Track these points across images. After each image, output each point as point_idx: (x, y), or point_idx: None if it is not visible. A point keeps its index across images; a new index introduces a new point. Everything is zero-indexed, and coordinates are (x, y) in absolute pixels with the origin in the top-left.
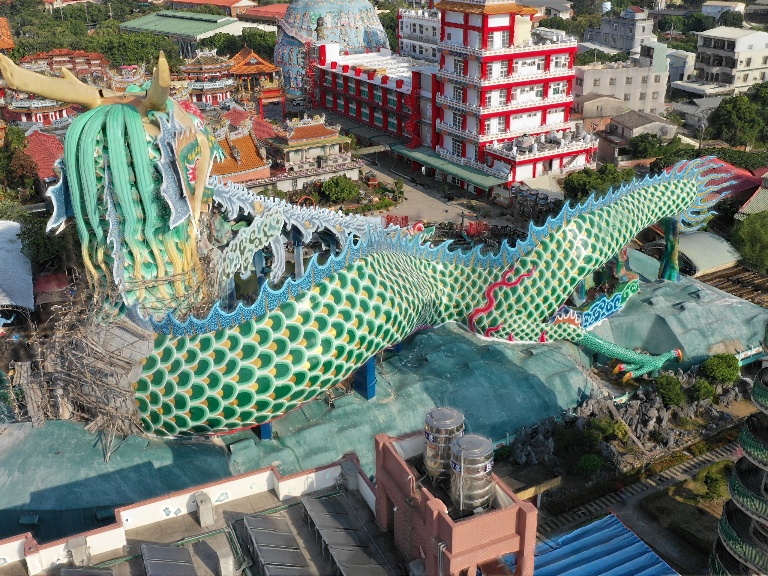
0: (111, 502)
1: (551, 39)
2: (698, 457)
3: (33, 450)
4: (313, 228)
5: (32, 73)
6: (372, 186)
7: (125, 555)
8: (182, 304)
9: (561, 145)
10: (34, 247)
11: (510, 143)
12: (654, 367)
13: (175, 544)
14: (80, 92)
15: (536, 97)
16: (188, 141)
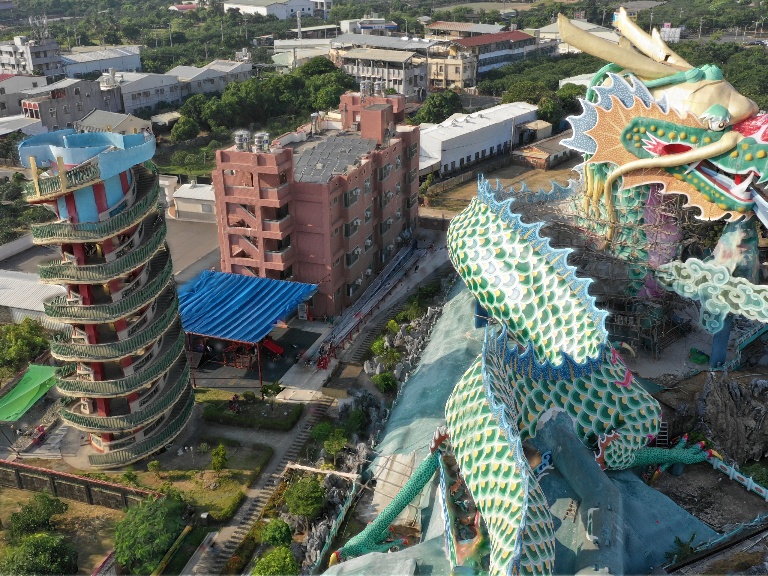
0: None
1: None
2: (254, 522)
3: None
4: None
5: None
6: None
7: None
8: None
9: None
10: None
11: None
12: None
13: None
14: None
15: None
16: None
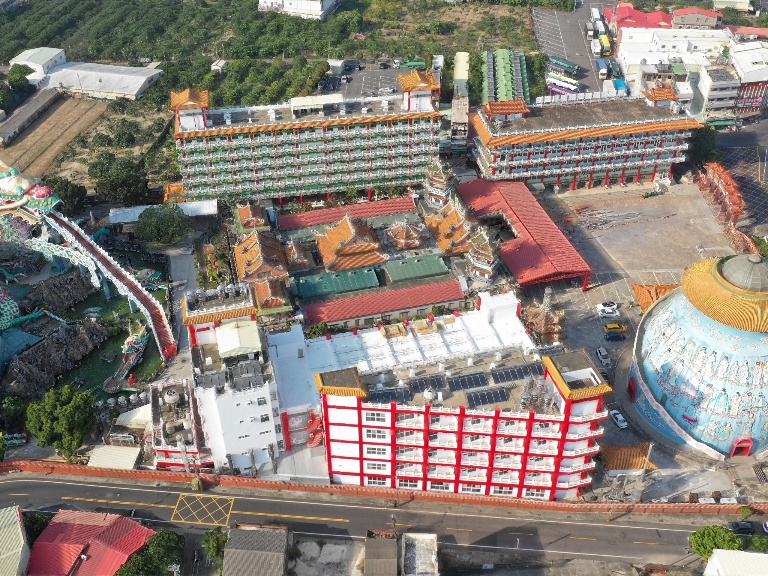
0: None
1: None
2: None
3: None
4: None
5: None
6: None
7: None
8: None
9: None
10: None
11: None
12: None
13: None
14: None
15: None
16: (3, 192)
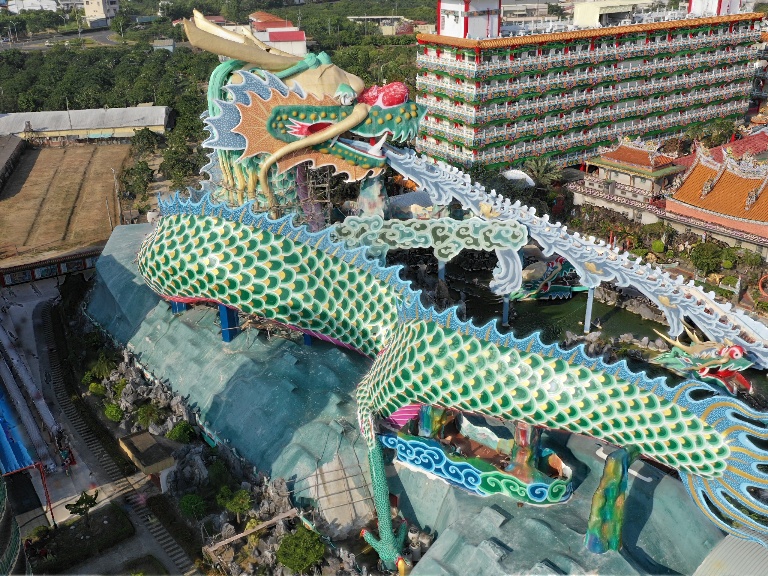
0: (105, 277)
1: None
2: None
3: None
4: (605, 276)
5: (214, 26)
6: None
7: None
8: None
9: None
10: None
11: None
12: None
13: None
14: None
15: None
16: (306, 103)
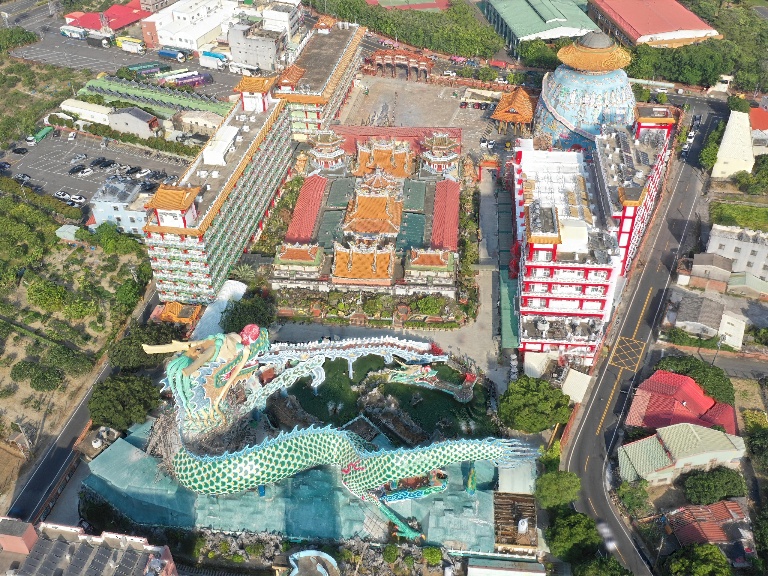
0: (148, 501)
1: (596, 257)
2: None
3: (139, 467)
4: (358, 355)
5: (156, 347)
6: (462, 303)
7: (100, 545)
8: (208, 428)
9: (567, 336)
10: (224, 324)
11: (541, 318)
12: (408, 536)
13: (111, 549)
14: (179, 348)
15: (576, 290)
16: (227, 364)
